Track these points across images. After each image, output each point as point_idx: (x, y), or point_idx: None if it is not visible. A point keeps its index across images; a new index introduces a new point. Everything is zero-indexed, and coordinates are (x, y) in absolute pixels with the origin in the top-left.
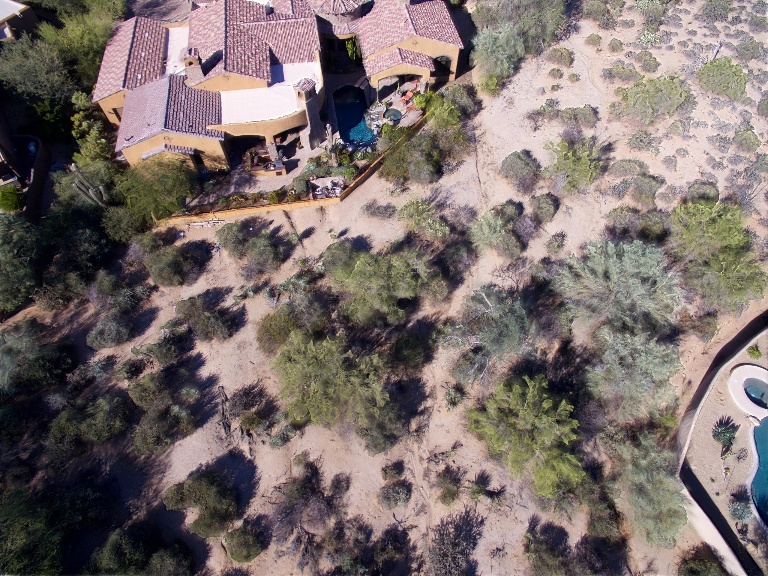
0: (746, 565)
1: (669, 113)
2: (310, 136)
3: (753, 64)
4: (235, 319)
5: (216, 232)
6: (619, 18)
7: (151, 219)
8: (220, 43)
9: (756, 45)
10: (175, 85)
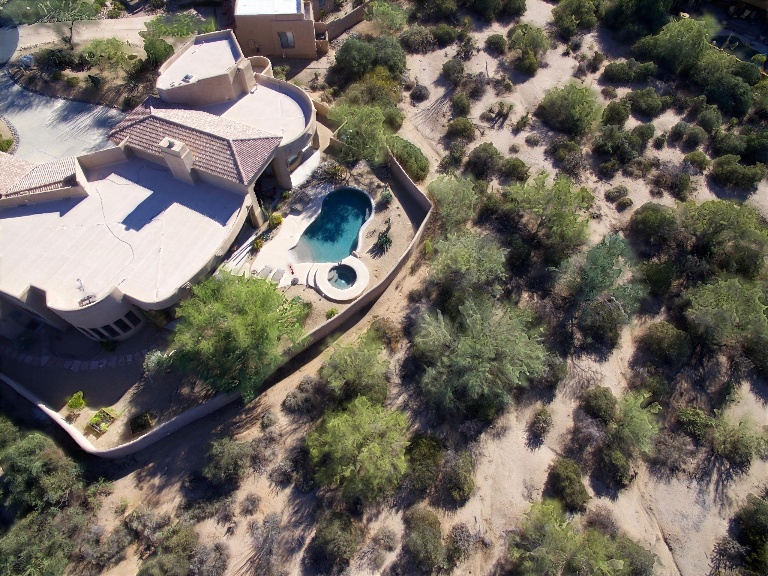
0: (386, 179)
1: None
2: None
3: None
4: None
5: None
6: None
7: None
8: None
9: None
10: None
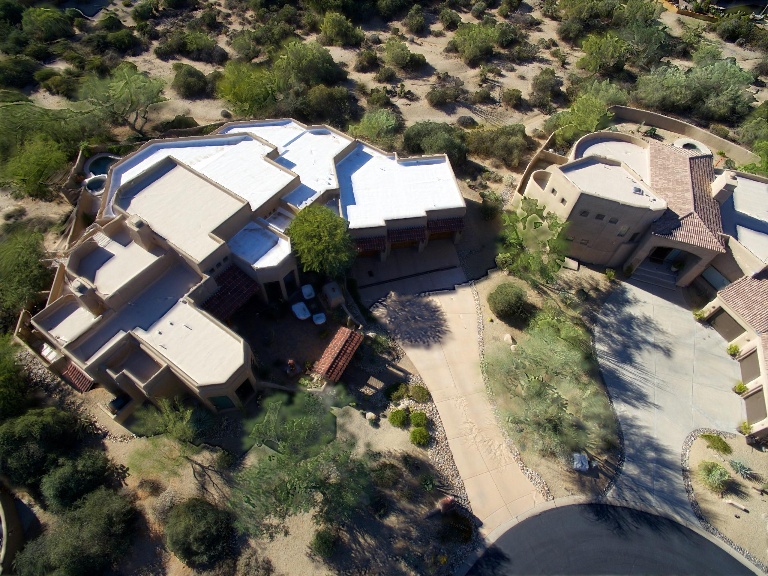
0: None
1: None
2: None
3: None
4: None
5: None
6: None
7: None
8: None
9: None
10: None
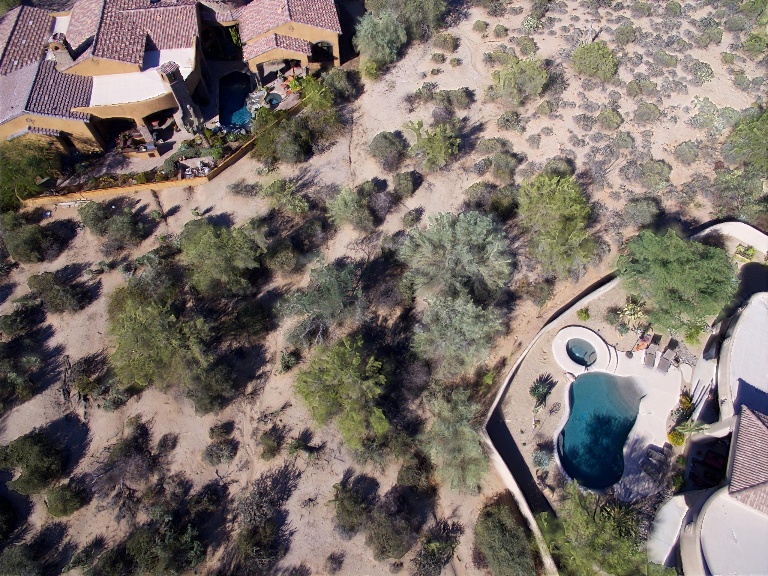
0: (542, 508)
1: (540, 94)
2: (184, 119)
3: (629, 48)
4: (88, 292)
5: (77, 210)
6: (509, 5)
7: (18, 199)
8: (93, 29)
9: (630, 29)
10: (44, 70)
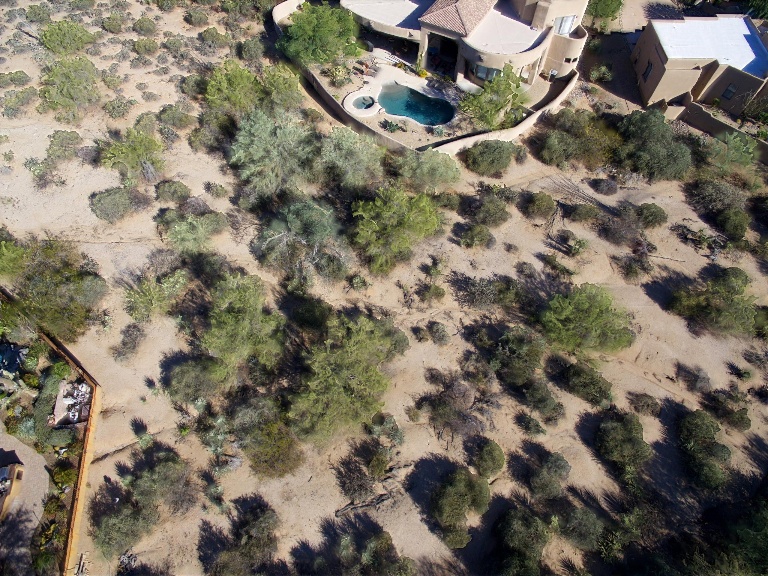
0: None
1: None
2: None
3: (56, 19)
4: (252, 508)
5: None
6: None
7: None
8: None
9: (37, 7)
10: None
